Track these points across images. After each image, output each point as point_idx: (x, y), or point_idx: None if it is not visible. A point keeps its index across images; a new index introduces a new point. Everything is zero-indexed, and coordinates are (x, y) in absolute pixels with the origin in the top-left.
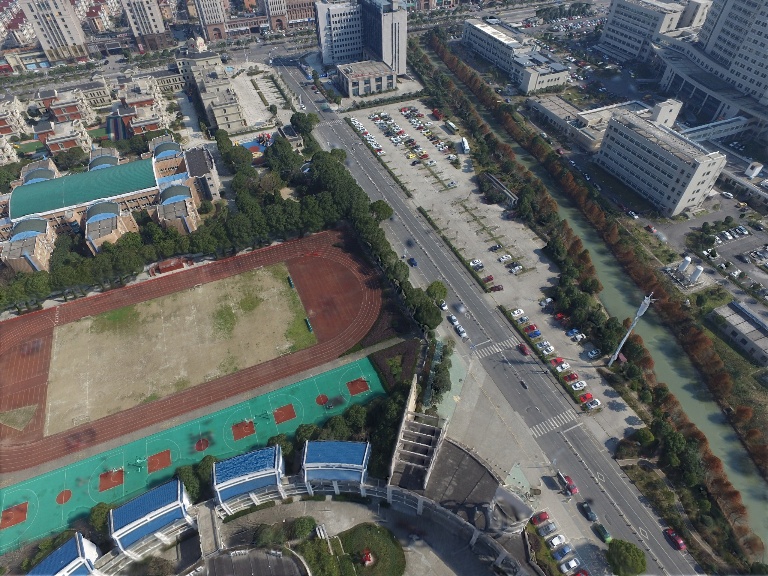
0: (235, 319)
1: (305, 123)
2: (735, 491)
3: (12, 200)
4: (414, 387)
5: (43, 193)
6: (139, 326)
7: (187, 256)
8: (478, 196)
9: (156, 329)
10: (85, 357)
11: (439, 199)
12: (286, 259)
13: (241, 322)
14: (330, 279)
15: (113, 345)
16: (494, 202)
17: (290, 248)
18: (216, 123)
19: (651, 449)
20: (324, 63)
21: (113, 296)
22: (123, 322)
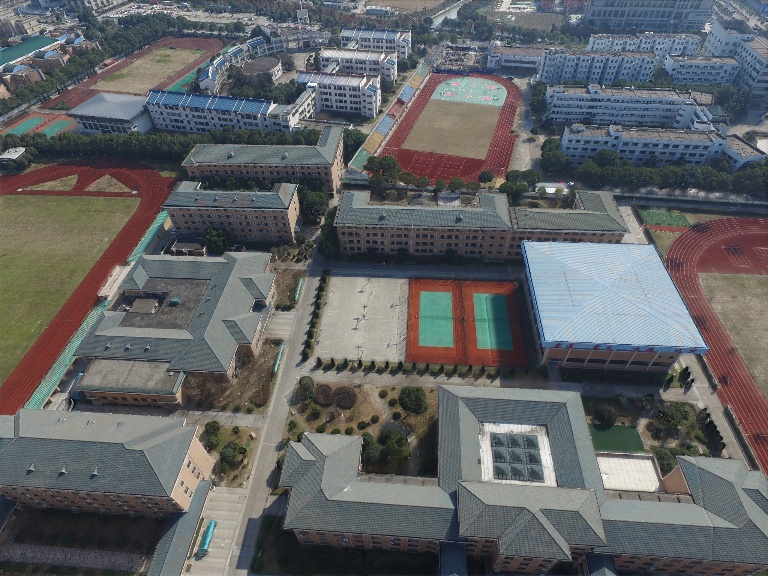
0: (167, 59)
1: (91, 15)
2: (348, 18)
3: None
4: None
5: None
6: (128, 74)
7: None
8: (213, 14)
9: None
10: (121, 84)
11: (198, 19)
12: None
13: None
14: None
15: (127, 79)
16: (222, 12)
17: (156, 45)
18: None
19: (327, 26)
20: (43, 6)
21: None
22: (119, 76)
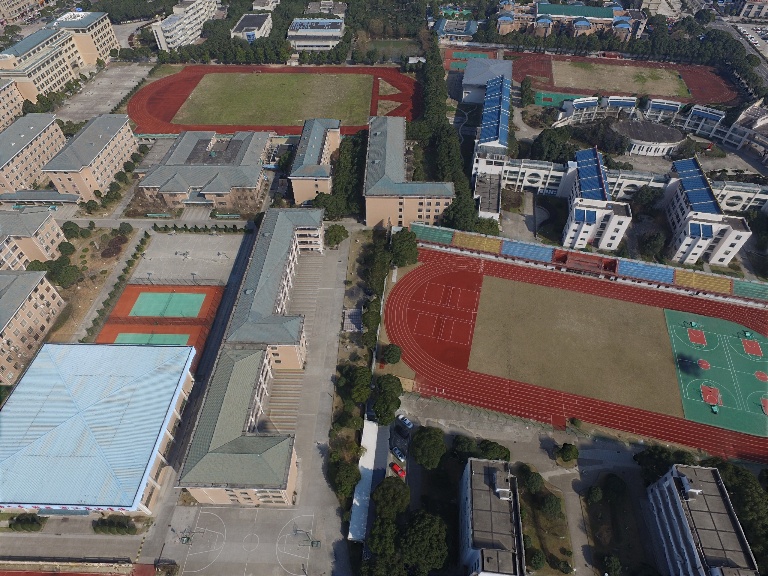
0: (646, 80)
1: (707, 16)
2: None
3: (539, 6)
4: (759, 104)
5: (554, 7)
6: (594, 70)
7: (621, 54)
8: None
9: (603, 73)
10: (569, 71)
11: None
12: (678, 69)
13: (650, 82)
14: (705, 82)
15: (582, 72)
16: None
17: (682, 66)
18: (638, 8)
19: None
20: None
21: (579, 58)
22: (586, 67)
